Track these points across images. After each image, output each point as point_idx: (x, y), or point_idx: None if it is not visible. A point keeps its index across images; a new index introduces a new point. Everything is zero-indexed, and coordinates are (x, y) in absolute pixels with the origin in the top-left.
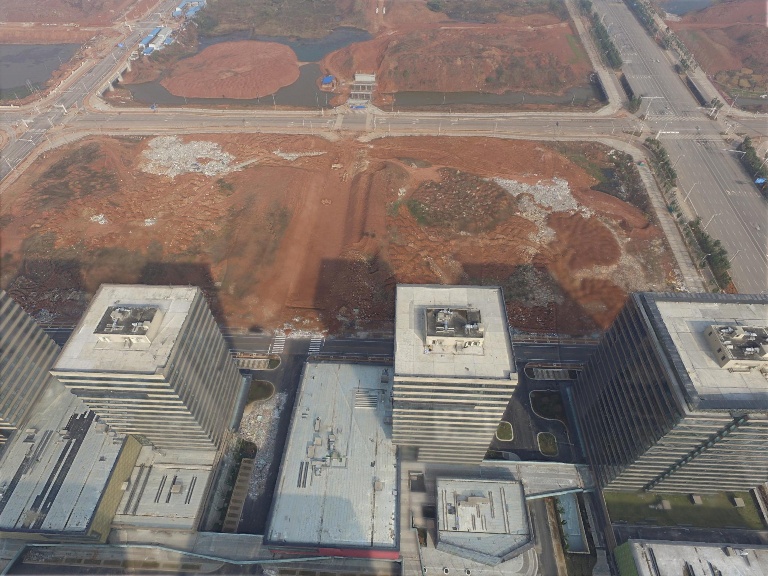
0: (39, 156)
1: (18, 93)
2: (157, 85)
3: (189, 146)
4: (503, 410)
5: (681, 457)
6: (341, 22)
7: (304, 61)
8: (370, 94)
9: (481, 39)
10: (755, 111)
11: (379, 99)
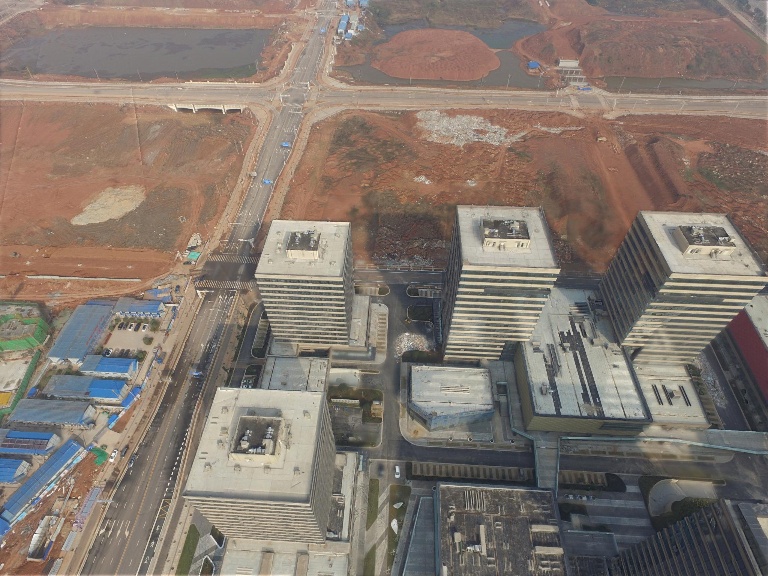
0: (312, 127)
1: (241, 72)
2: (368, 67)
3: (458, 119)
4: None
5: None
6: (509, 13)
7: (497, 48)
8: (584, 78)
9: (665, 30)
10: None
11: (592, 83)
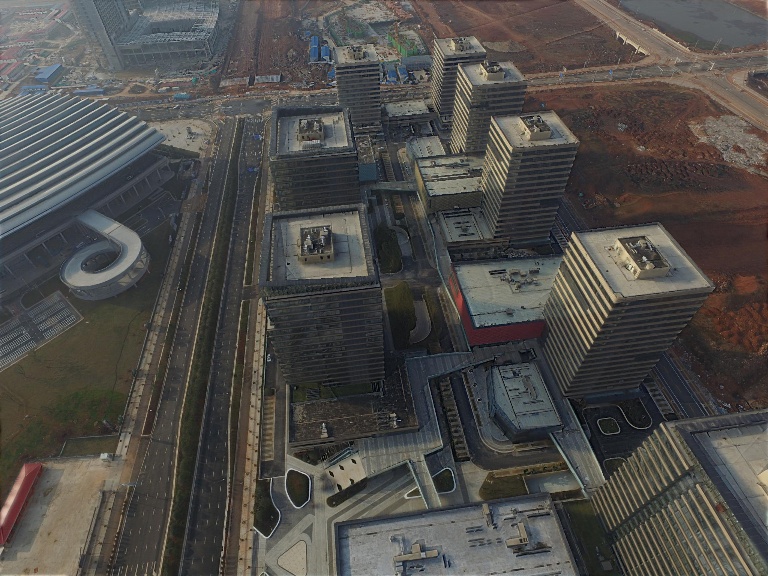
0: (653, 82)
1: (706, 45)
2: None
3: (746, 135)
4: (598, 330)
5: (644, 502)
6: None
7: None
8: None
9: None
10: None
11: None
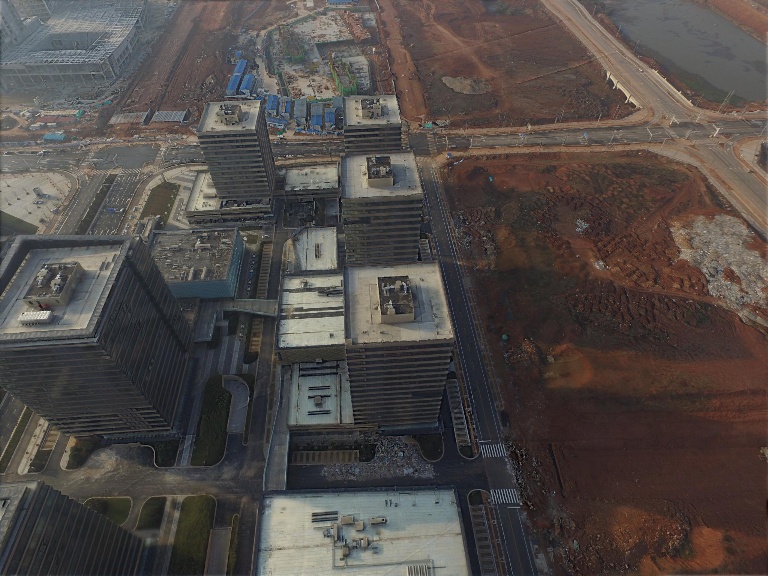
0: (638, 150)
1: (715, 95)
2: None
3: (745, 252)
4: None
5: None
6: None
7: None
8: None
9: None
10: None
11: None
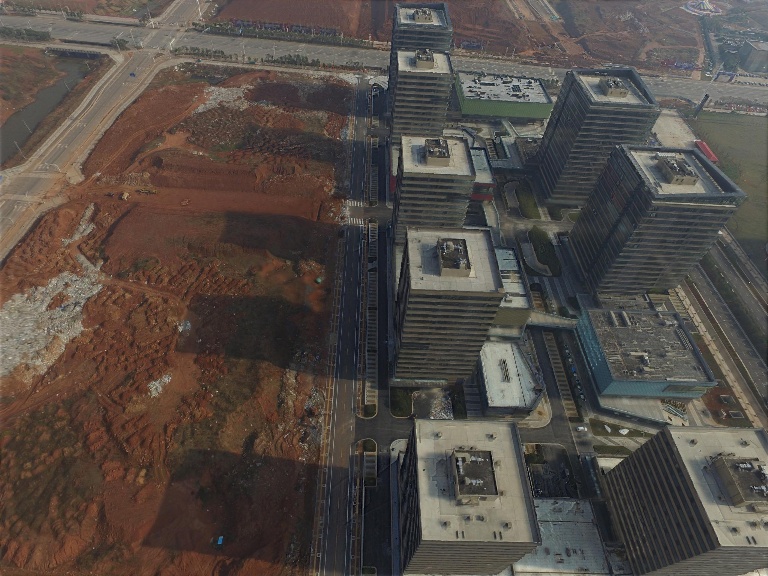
0: None
1: None
2: None
3: (4, 325)
4: None
5: None
6: None
7: None
8: None
9: None
10: (157, 15)
11: None
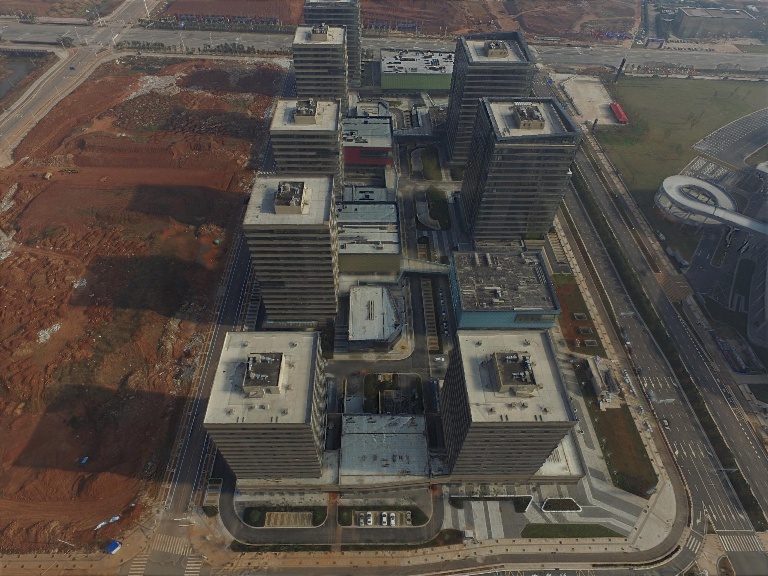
0: None
1: None
2: None
3: None
4: None
5: None
6: None
7: None
8: None
9: None
10: None
11: None
